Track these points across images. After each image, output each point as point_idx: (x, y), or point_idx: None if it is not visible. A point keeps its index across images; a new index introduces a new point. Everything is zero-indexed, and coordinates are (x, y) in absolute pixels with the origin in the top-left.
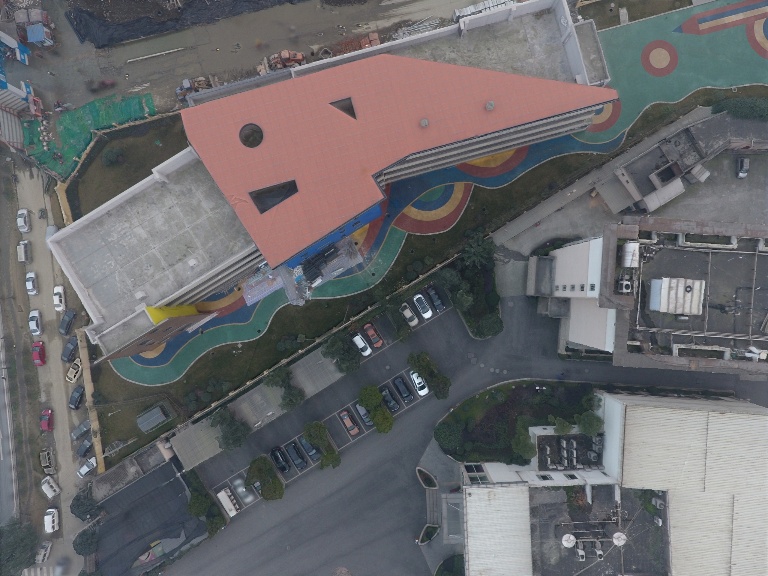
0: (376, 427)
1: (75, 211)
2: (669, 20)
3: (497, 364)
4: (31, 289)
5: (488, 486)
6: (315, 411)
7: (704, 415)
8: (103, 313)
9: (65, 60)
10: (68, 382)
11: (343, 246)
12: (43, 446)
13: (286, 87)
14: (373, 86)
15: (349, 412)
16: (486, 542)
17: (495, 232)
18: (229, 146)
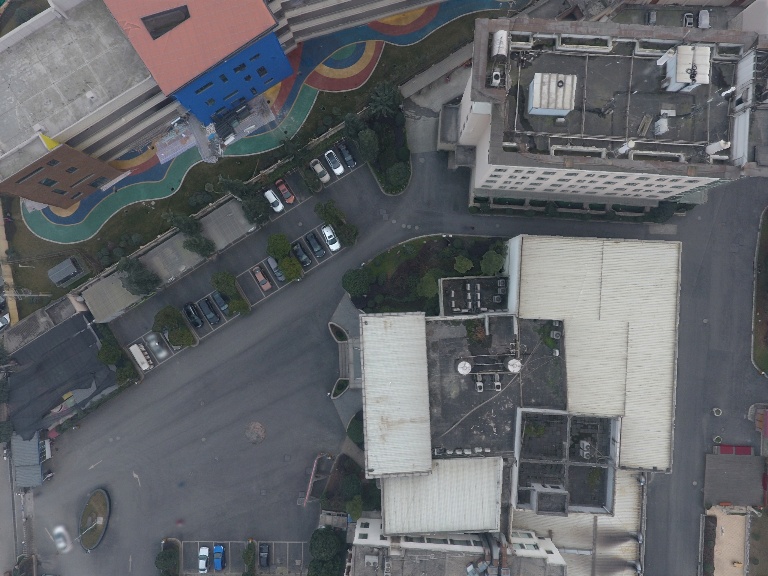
0: None
1: None
2: None
3: (409, 220)
4: None
5: (384, 314)
6: (228, 268)
7: (599, 244)
8: (3, 148)
9: None
10: None
11: (255, 104)
12: None
13: None
14: None
15: (262, 268)
16: (382, 370)
17: (403, 85)
18: None
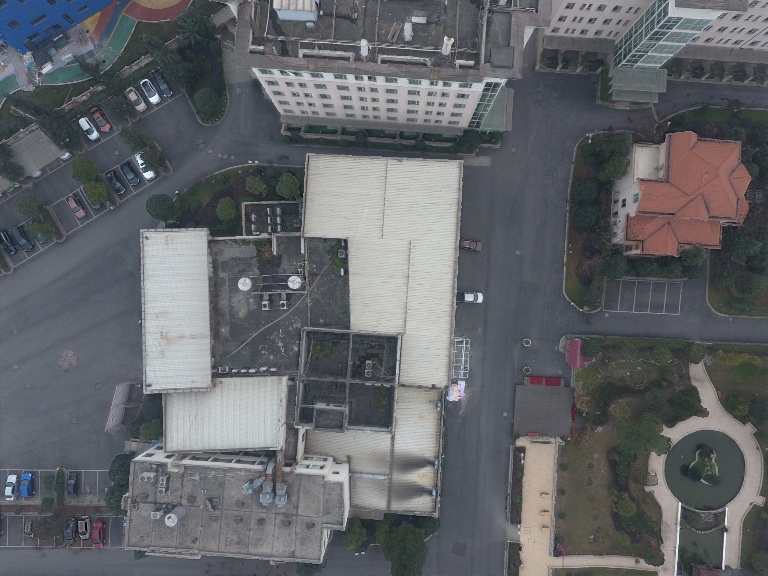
0: None
1: None
2: None
3: (225, 150)
4: None
5: (165, 230)
6: (44, 196)
7: (383, 163)
8: None
9: None
10: None
11: (74, 34)
12: None
13: None
14: None
15: (77, 196)
16: (163, 285)
17: (216, 13)
18: None
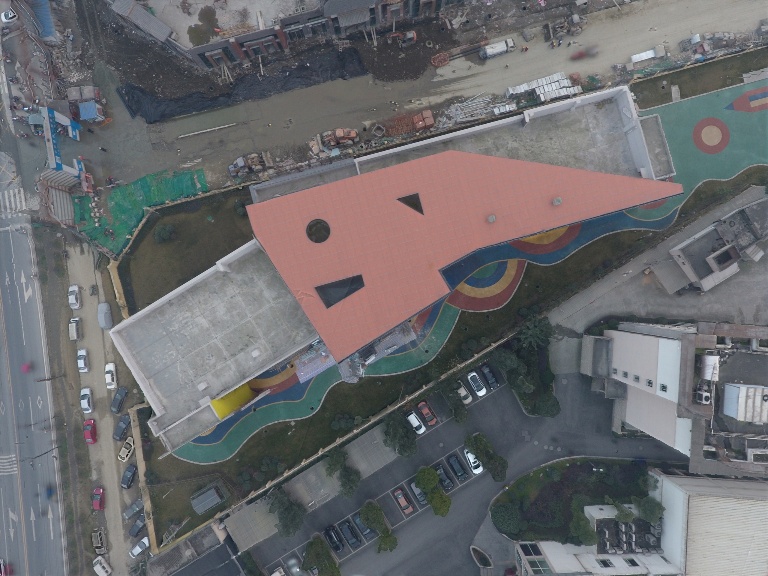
0: (432, 507)
1: (127, 288)
2: (721, 97)
3: (551, 441)
4: (83, 367)
5: None
6: (368, 489)
7: (767, 505)
8: (164, 403)
9: (116, 135)
10: (119, 460)
11: None
12: (94, 525)
13: (354, 183)
14: (441, 182)
15: (403, 490)
16: None
17: None
18: (296, 241)
